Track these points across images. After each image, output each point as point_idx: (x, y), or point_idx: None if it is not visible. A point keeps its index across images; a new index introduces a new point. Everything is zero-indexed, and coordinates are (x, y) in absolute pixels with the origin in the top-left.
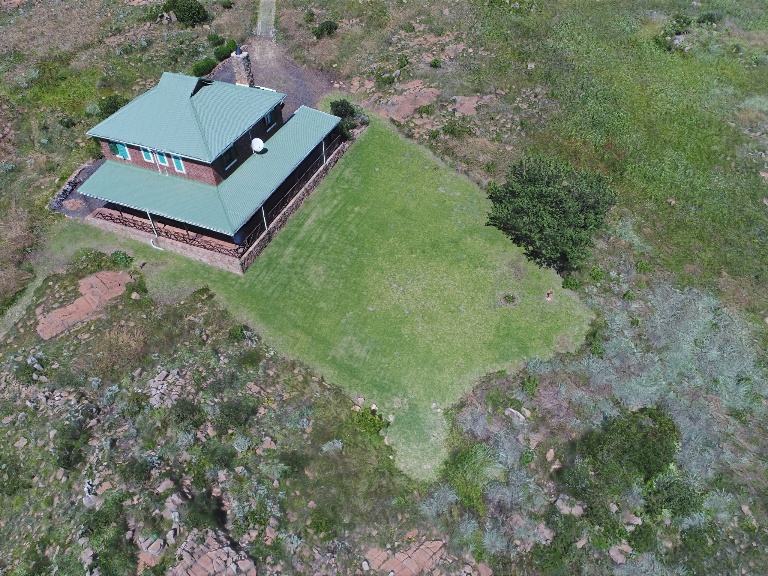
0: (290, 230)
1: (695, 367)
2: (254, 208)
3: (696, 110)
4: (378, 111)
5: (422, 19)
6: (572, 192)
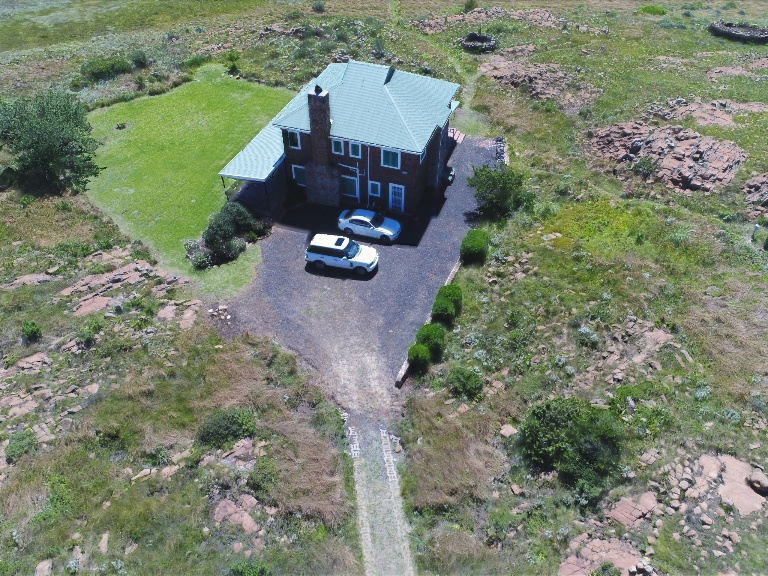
0: None
1: None
2: None
3: None
4: None
5: None
6: None
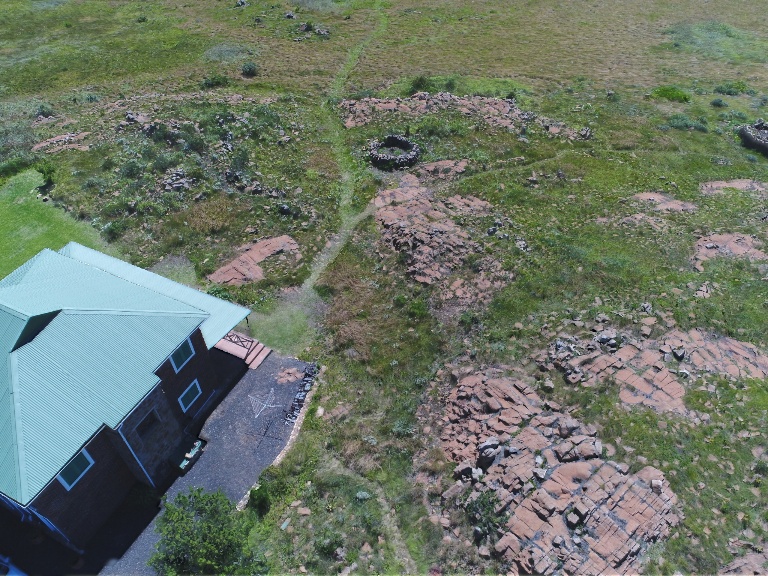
0: None
1: None
2: None
3: None
4: None
5: None
6: None
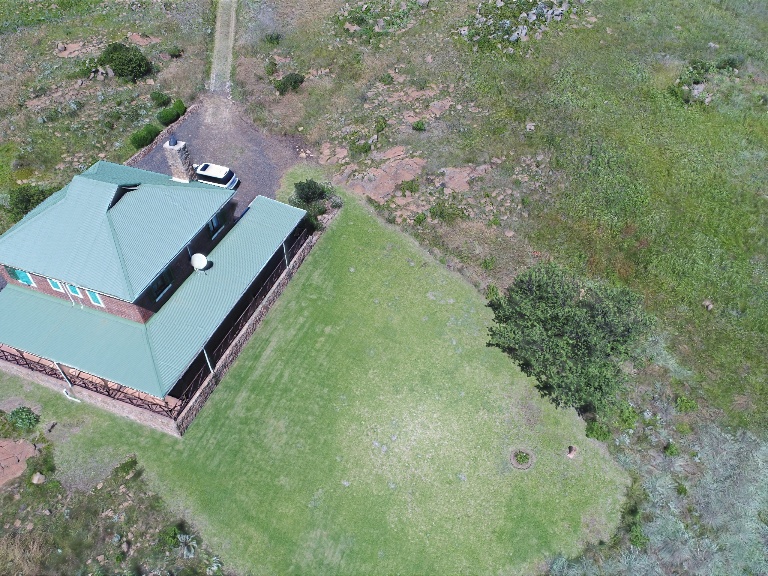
0: (244, 365)
1: (764, 557)
2: (192, 355)
3: (725, 180)
4: (352, 188)
5: (402, 68)
6: (597, 321)
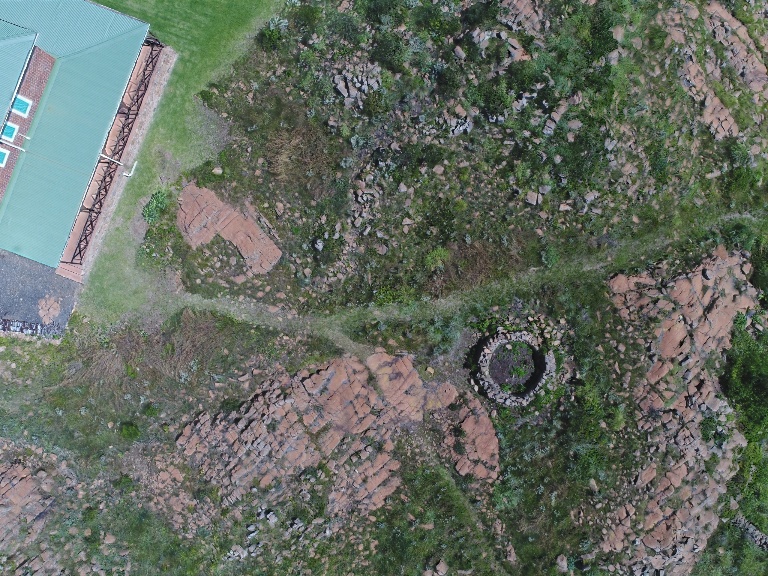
0: None
1: None
2: (96, 7)
3: None
4: None
5: None
6: None
